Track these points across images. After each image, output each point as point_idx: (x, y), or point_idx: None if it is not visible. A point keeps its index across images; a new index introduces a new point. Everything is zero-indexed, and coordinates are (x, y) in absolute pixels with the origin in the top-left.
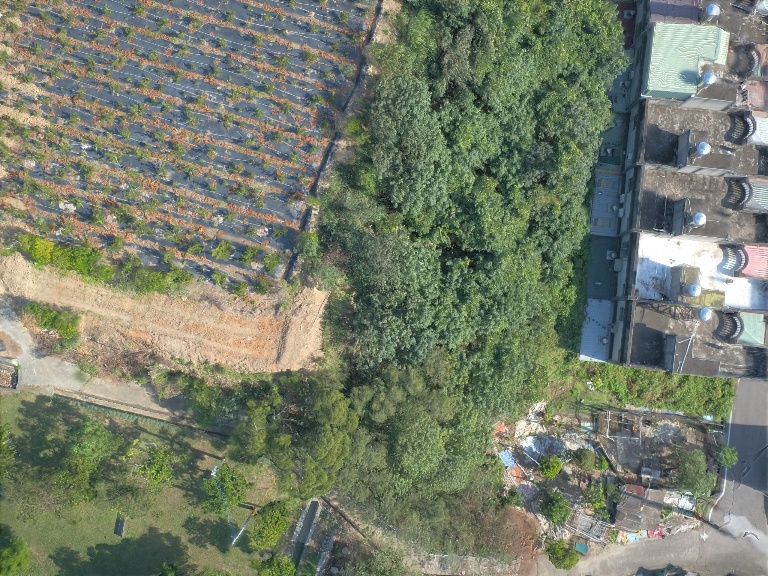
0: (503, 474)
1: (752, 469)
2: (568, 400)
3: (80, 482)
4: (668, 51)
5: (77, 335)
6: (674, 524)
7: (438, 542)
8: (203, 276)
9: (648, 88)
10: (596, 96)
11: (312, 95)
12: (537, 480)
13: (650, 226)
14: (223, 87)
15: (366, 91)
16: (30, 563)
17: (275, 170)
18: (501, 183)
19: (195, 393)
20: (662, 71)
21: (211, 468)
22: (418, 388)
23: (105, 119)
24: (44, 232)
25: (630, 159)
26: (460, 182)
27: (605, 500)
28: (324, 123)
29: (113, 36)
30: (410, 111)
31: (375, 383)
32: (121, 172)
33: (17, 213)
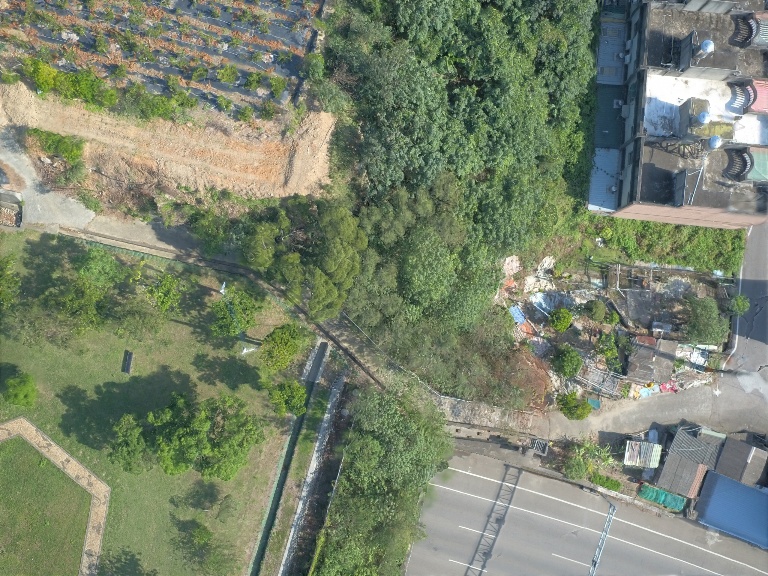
0: (513, 330)
1: (764, 319)
2: (577, 257)
3: (87, 307)
4: None
5: (82, 164)
6: (686, 379)
7: (450, 374)
8: (208, 103)
9: None
10: None
11: None
12: (547, 335)
13: (657, 65)
14: None
15: None
16: (37, 402)
17: None
18: (507, 17)
19: (202, 221)
20: None
21: None
22: (428, 206)
23: None
24: (47, 62)
25: (636, 1)
26: (466, 8)
27: (617, 349)
28: None
29: None
30: None
31: (384, 205)
32: (124, 2)
33: (19, 42)
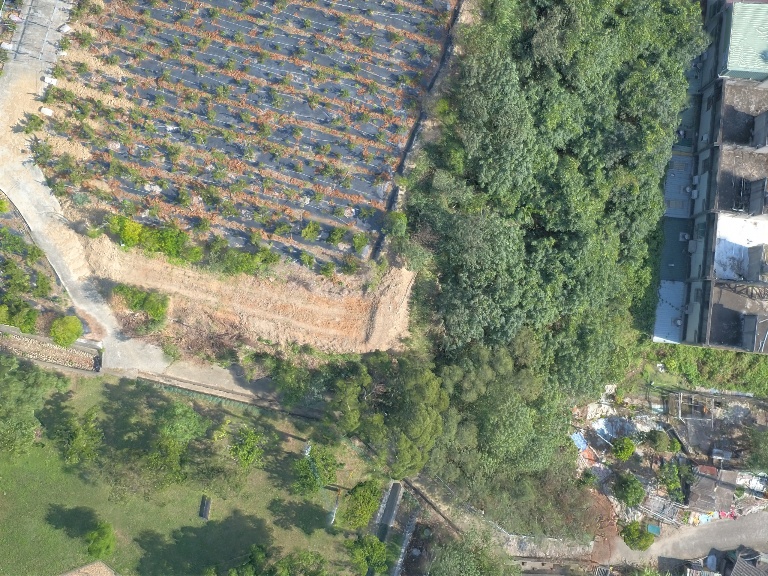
0: None
1: None
2: (638, 382)
3: (171, 463)
4: (748, 31)
5: (164, 317)
6: (745, 505)
7: (524, 522)
8: (290, 257)
9: (727, 68)
10: (675, 76)
11: (397, 75)
12: (610, 462)
13: (727, 207)
14: (308, 68)
15: (451, 71)
16: (116, 546)
17: (361, 151)
18: (582, 164)
19: (283, 374)
20: (741, 51)
21: (296, 450)
22: (509, 367)
23: (190, 100)
24: (130, 214)
25: (705, 140)
26: (545, 162)
27: (680, 481)
28: (410, 103)
29: (197, 17)
30: (501, 90)
31: (464, 363)
32: (206, 153)
33: (103, 195)
